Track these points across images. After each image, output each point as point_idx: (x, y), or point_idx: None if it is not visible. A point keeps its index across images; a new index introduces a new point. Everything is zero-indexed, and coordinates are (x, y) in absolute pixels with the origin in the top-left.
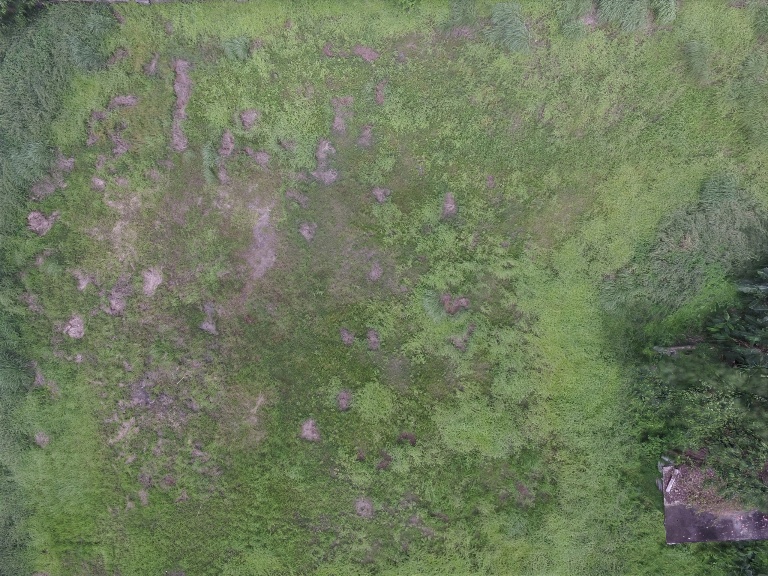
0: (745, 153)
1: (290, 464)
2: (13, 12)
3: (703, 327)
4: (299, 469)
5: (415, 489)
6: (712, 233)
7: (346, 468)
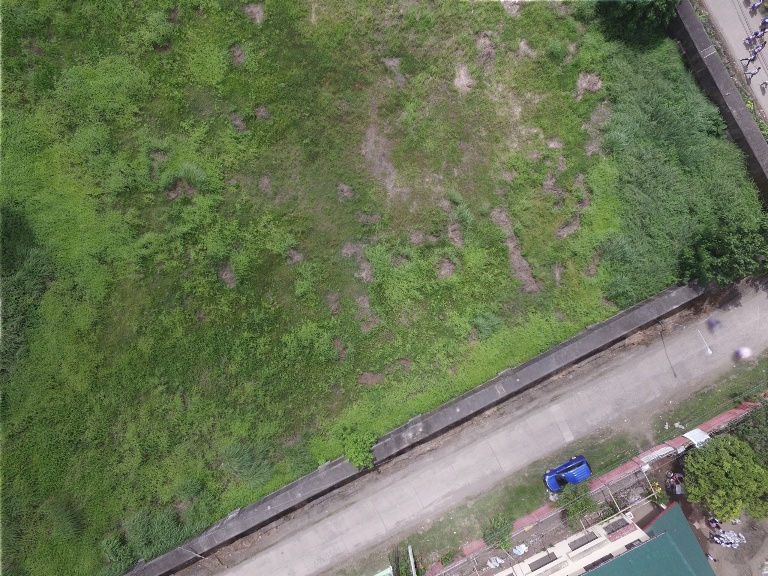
0: None
1: None
2: (698, 254)
3: None
4: None
5: (134, 5)
6: None
7: None
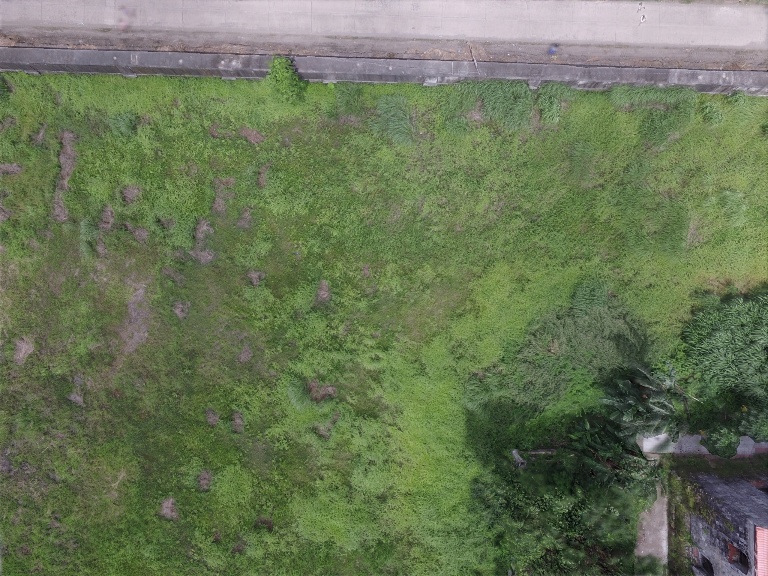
0: (621, 259)
1: (147, 542)
2: None
3: (566, 432)
4: (155, 547)
5: (269, 575)
6: (579, 340)
7: (202, 549)
